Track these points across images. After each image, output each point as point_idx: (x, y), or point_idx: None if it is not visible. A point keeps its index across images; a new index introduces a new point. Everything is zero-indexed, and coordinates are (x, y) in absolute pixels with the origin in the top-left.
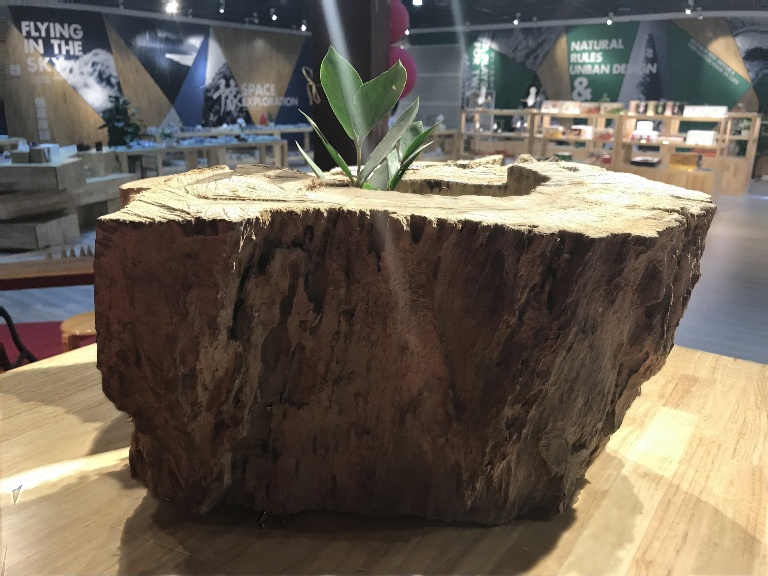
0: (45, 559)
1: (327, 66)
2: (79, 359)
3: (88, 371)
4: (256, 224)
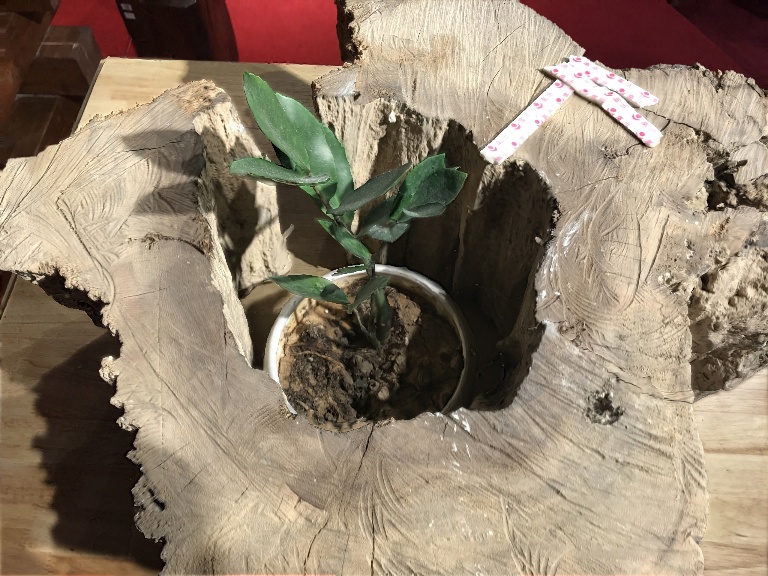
0: None
1: (251, 88)
2: None
3: None
4: (33, 273)
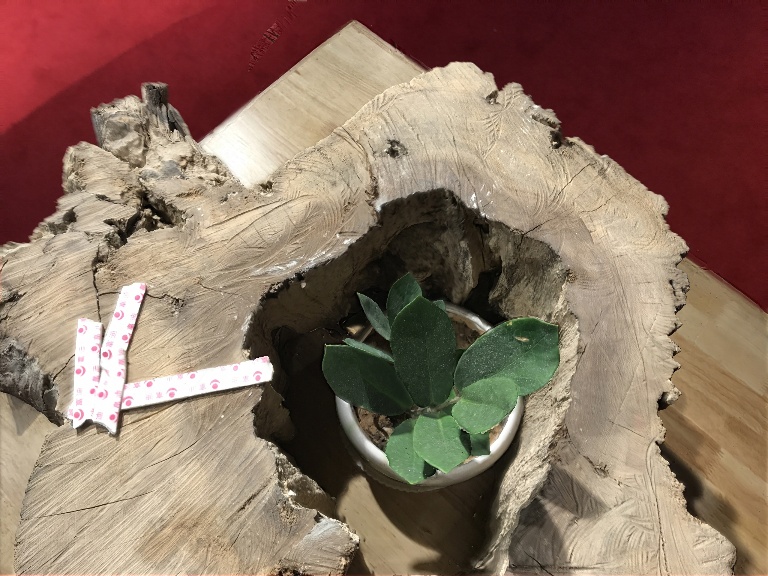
0: None
1: None
2: None
3: None
4: None
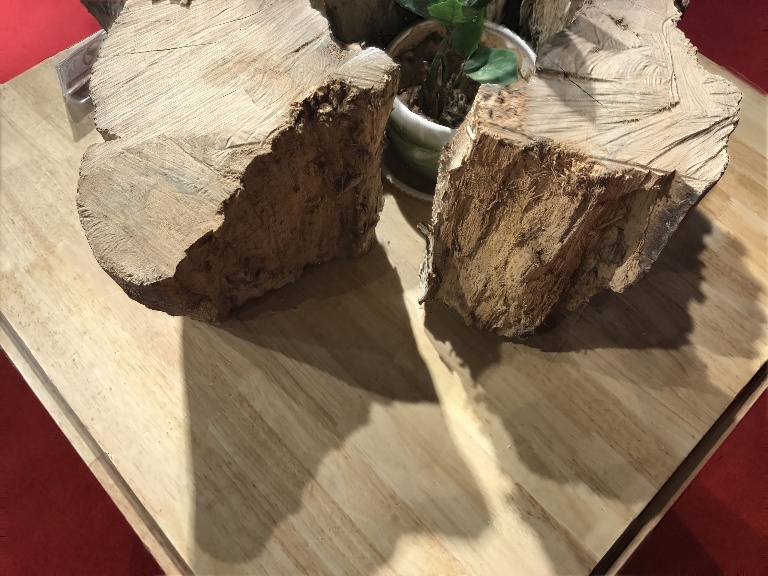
0: (588, 402)
1: None
2: (174, 472)
3: (223, 449)
4: None
